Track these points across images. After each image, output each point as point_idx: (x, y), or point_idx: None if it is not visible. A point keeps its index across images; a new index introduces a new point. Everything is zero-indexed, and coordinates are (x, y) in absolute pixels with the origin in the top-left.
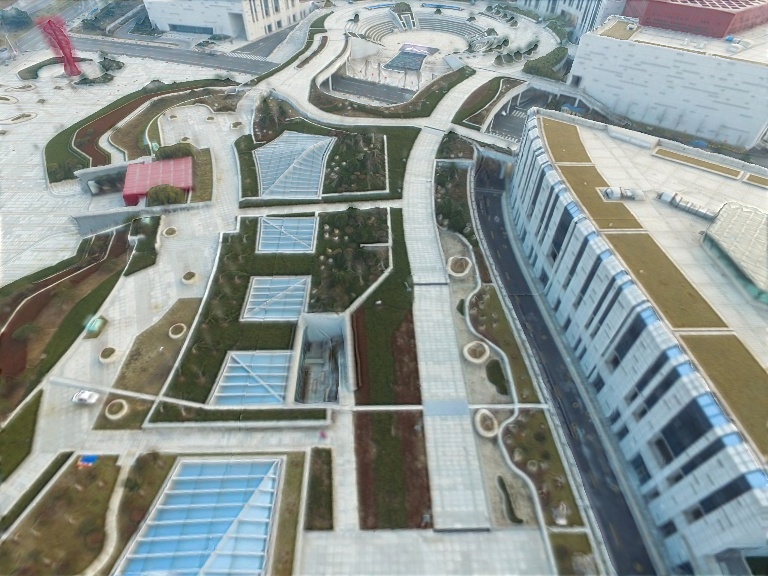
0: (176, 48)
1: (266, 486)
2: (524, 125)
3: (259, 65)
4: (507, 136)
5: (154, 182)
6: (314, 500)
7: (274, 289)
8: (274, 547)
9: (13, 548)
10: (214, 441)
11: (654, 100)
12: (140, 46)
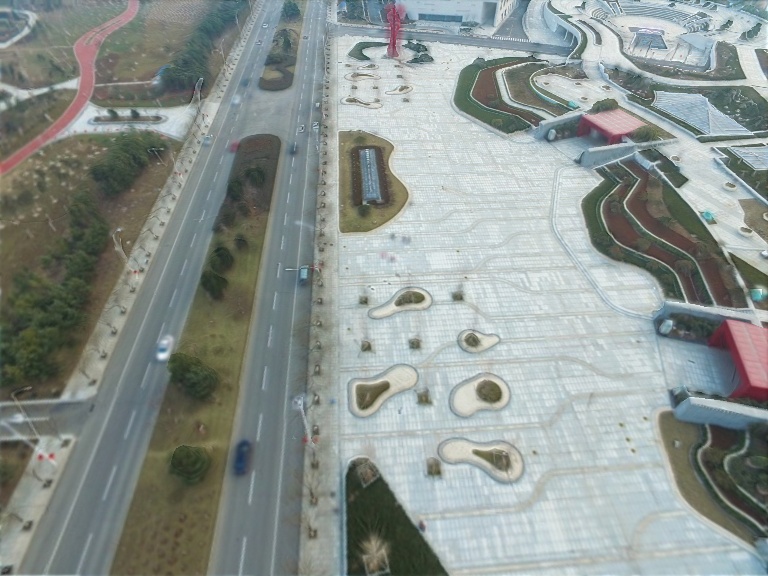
0: (444, 34)
1: None
2: None
3: (532, 46)
4: None
5: (623, 126)
6: None
7: None
8: None
9: None
10: None
11: None
12: (413, 32)
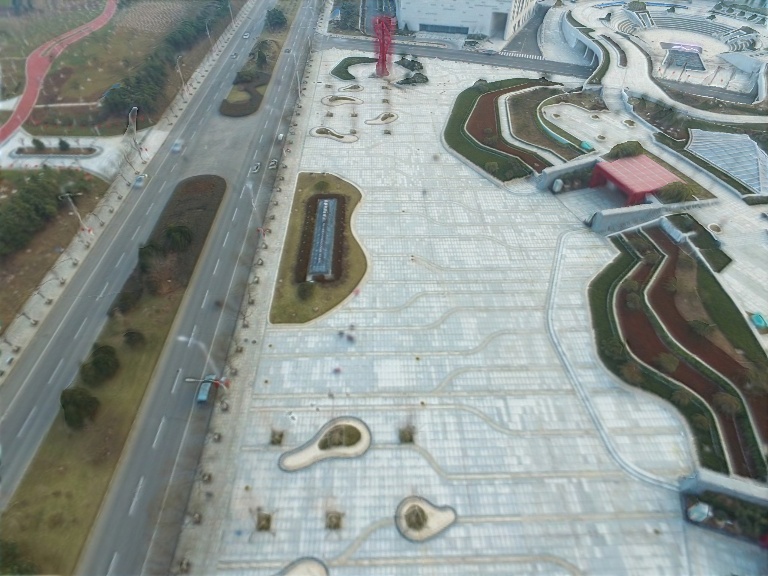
0: (446, 48)
1: None
2: None
3: (545, 64)
4: None
5: (647, 180)
6: None
7: None
8: None
9: None
10: None
11: None
12: (410, 46)
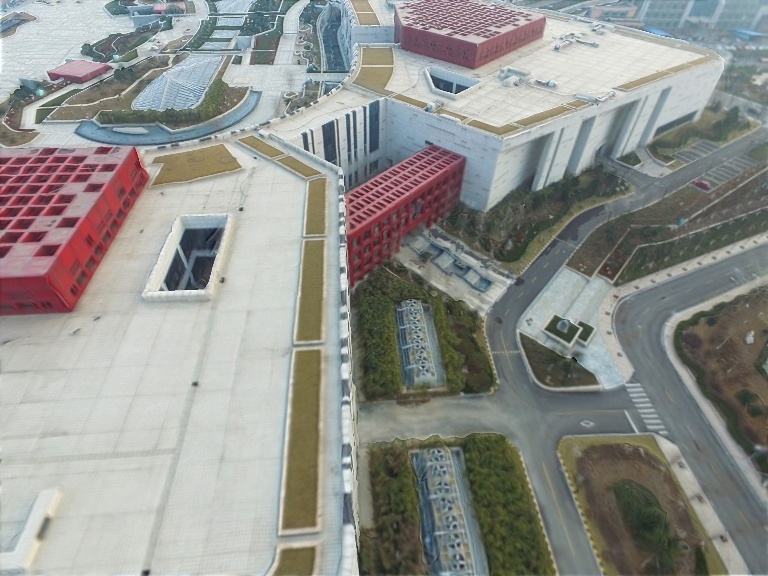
0: None
1: (220, 58)
2: None
3: None
4: None
5: None
6: None
7: None
8: None
9: None
10: None
11: None
12: None
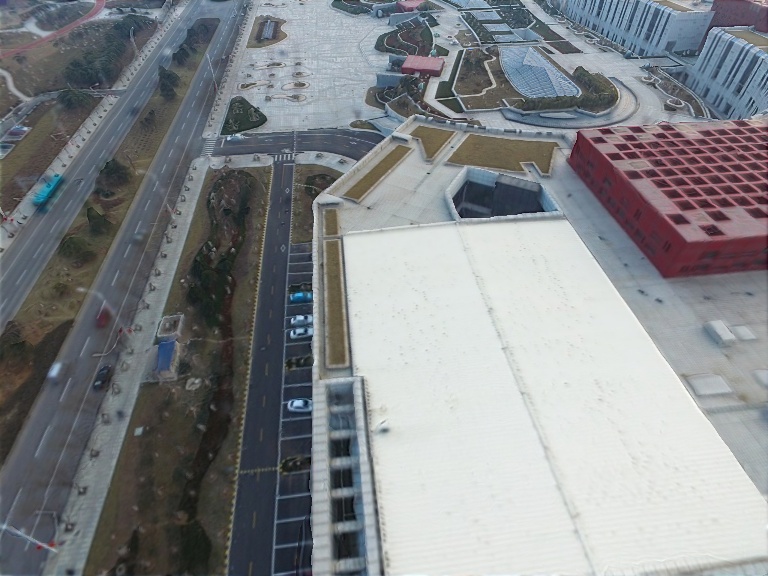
0: None
1: None
2: None
3: None
4: None
5: (416, 4)
6: None
7: None
8: None
9: None
10: None
11: None
12: None
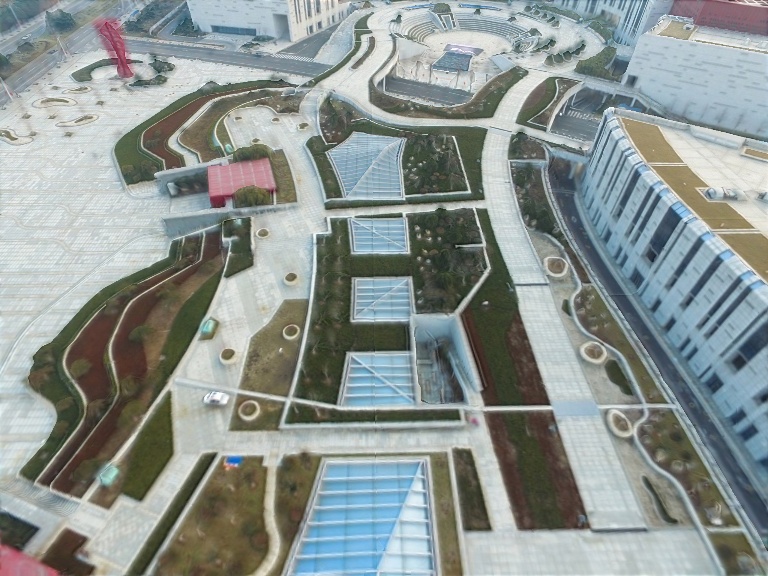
0: (222, 49)
1: (417, 487)
2: (600, 125)
3: (307, 66)
4: (568, 136)
5: (238, 183)
6: (467, 500)
7: (378, 290)
8: (438, 547)
9: (180, 549)
10: (353, 442)
11: (714, 100)
12: (186, 48)
